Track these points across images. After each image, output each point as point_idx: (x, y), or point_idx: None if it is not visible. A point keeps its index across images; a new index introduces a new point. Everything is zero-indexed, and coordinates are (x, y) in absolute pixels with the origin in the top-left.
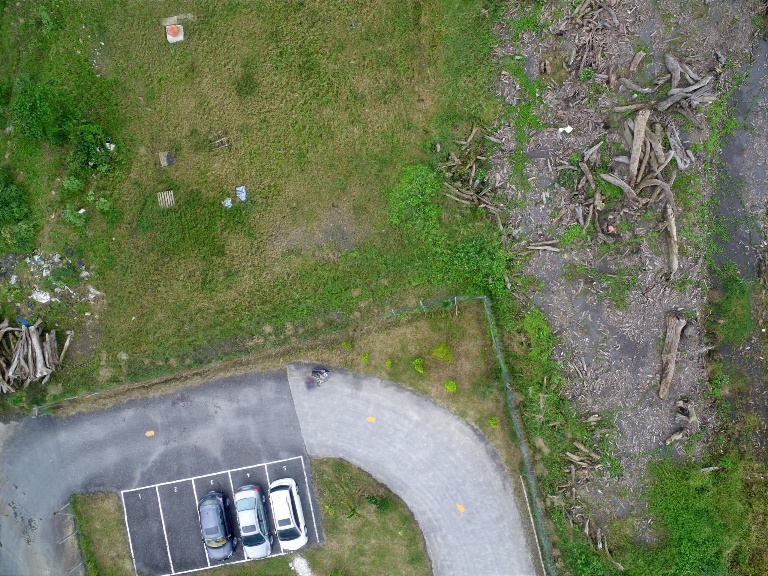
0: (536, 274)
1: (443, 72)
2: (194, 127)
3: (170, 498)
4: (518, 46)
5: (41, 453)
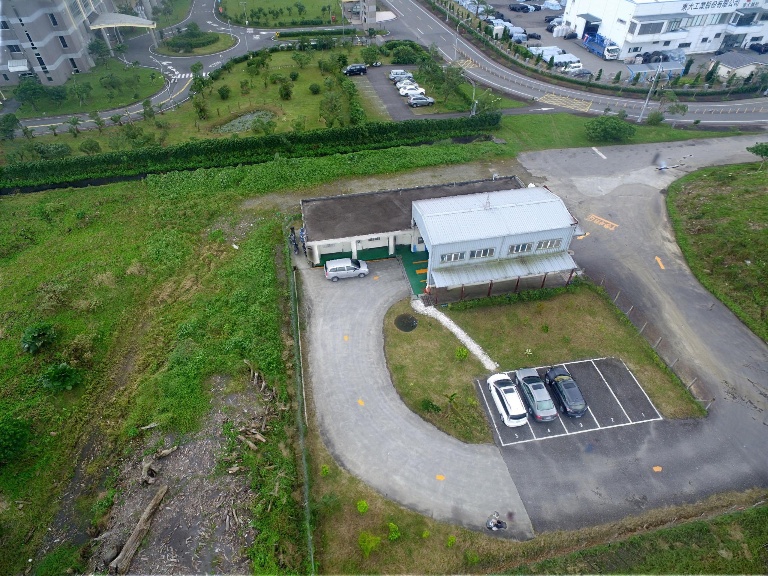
0: None
1: None
2: None
3: (615, 413)
4: None
5: (759, 453)
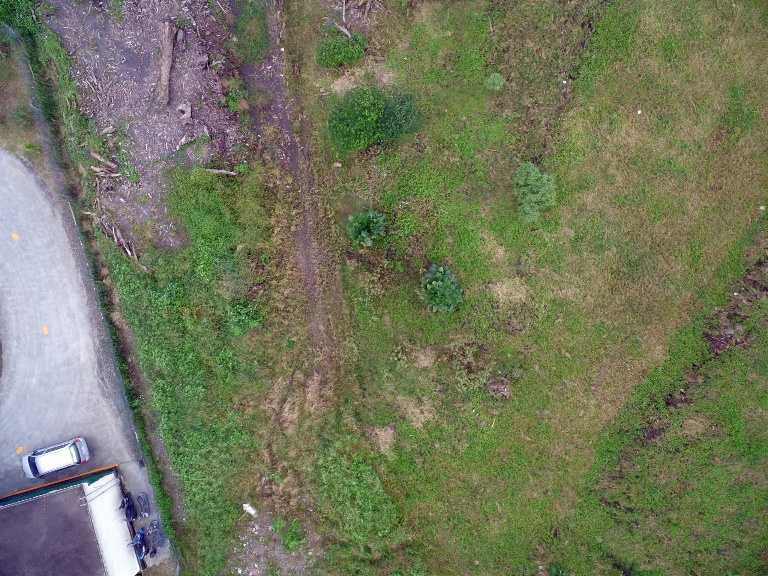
0: (51, 0)
1: None
2: None
3: None
4: None
5: None
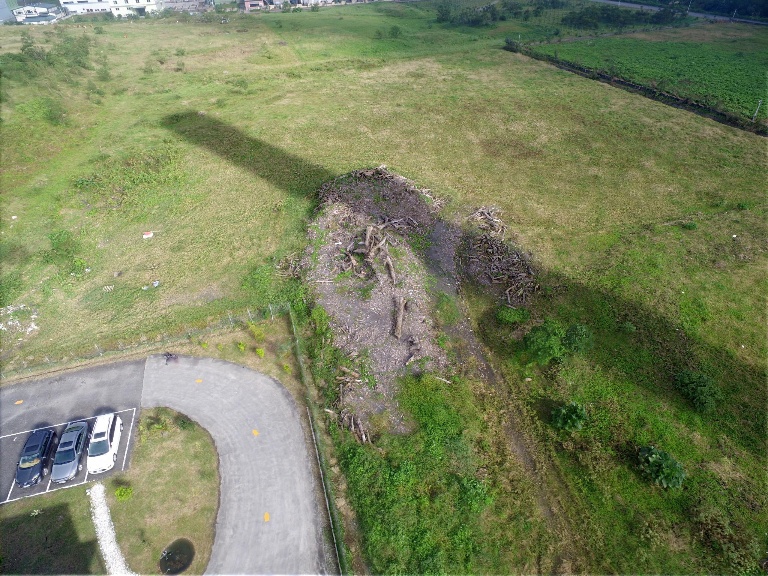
0: (320, 292)
1: (282, 237)
2: (141, 263)
3: (6, 446)
4: (316, 221)
5: None
